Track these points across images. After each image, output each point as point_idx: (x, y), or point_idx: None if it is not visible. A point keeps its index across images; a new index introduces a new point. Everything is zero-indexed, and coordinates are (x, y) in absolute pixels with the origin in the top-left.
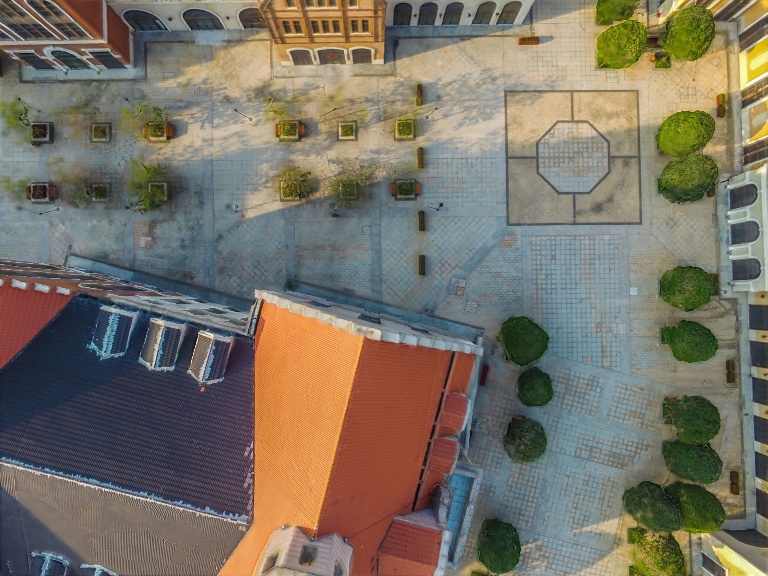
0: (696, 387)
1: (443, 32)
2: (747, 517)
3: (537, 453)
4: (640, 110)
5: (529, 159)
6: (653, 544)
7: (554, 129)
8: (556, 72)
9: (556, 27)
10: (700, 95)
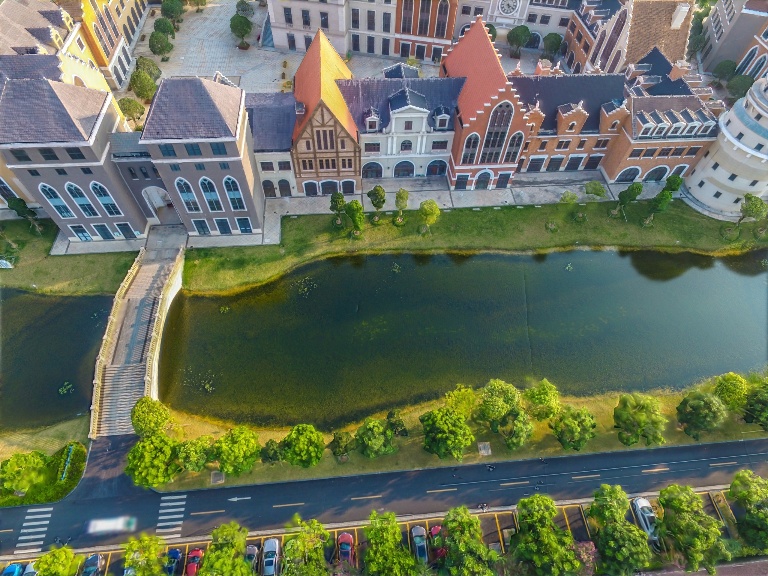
0: None
1: None
2: (151, 7)
3: None
4: None
5: None
6: None
7: None
8: None
9: None
10: None
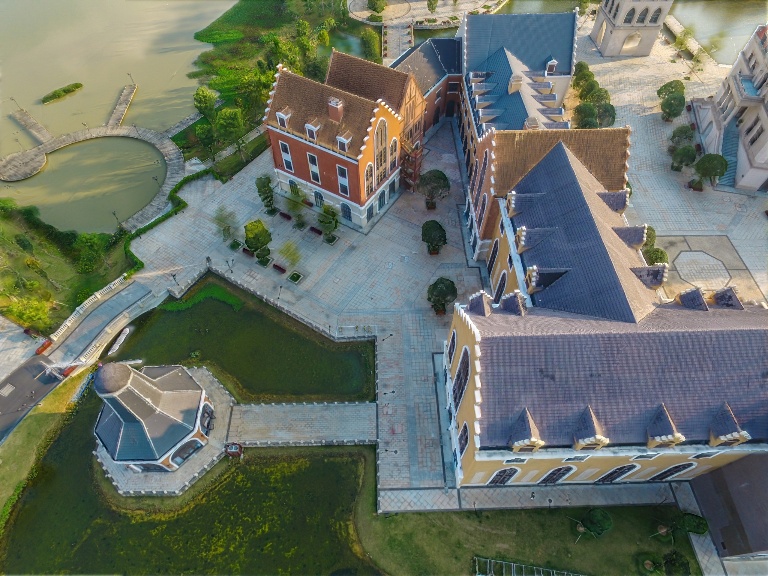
0: None
1: None
2: None
3: None
4: None
5: (732, 269)
6: None
7: None
8: None
9: None
10: None
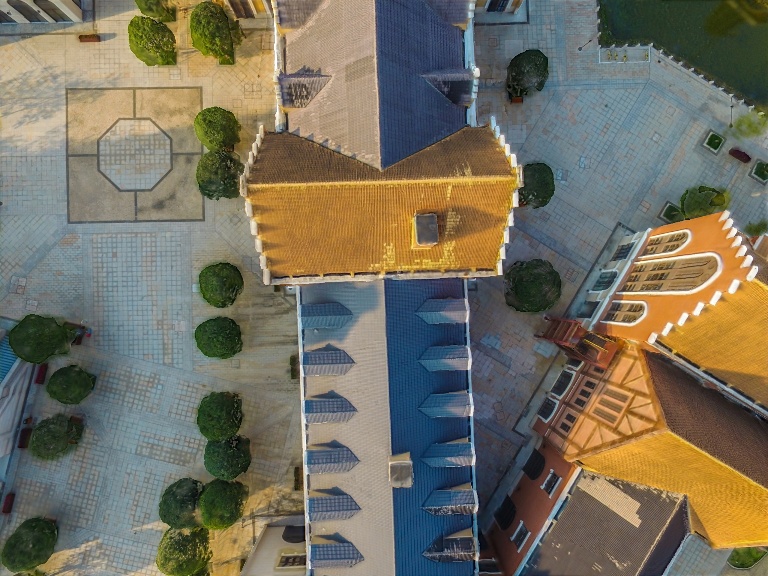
0: (260, 383)
1: (3, 30)
2: None
3: (44, 451)
4: (204, 107)
5: (90, 157)
6: (166, 541)
7: (116, 126)
8: (118, 69)
9: (119, 24)
10: (265, 91)
